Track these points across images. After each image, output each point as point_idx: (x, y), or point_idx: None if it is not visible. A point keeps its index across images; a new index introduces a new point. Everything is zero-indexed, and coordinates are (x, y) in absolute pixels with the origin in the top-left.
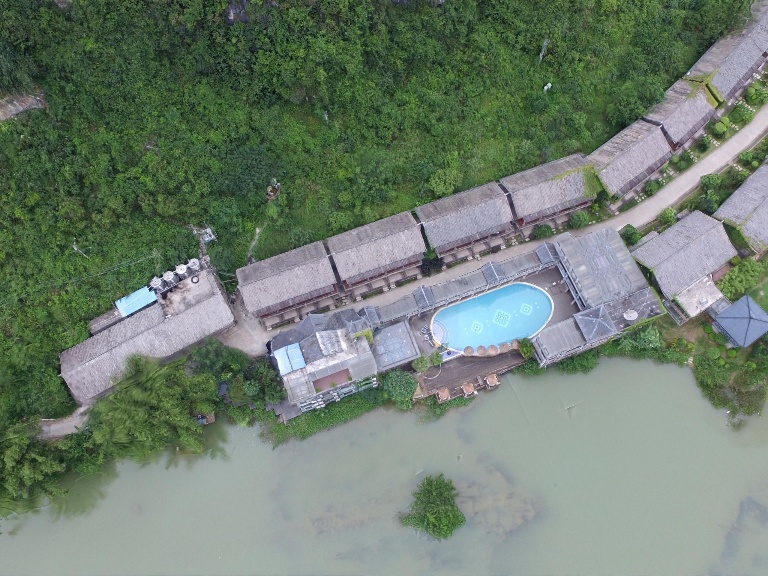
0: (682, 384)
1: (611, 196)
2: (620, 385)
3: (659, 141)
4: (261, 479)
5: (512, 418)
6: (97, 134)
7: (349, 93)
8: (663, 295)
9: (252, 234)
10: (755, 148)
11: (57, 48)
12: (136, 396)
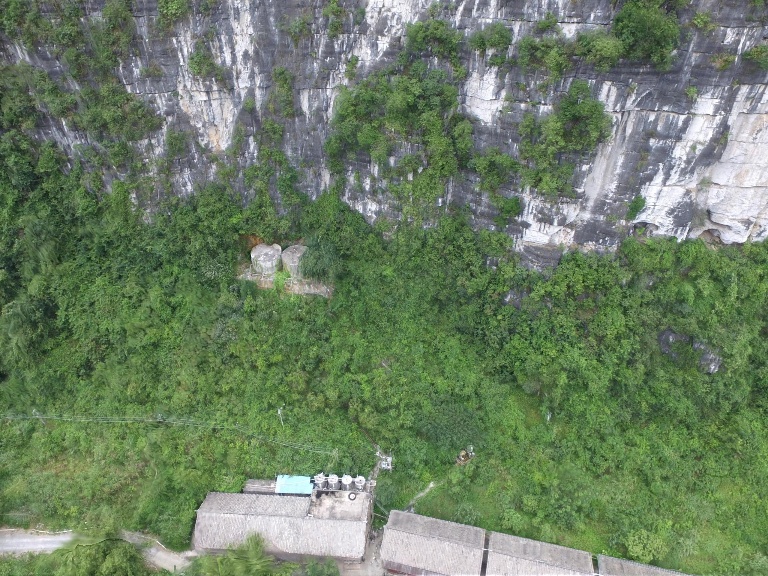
0: None
1: None
2: None
3: None
4: None
5: None
6: (352, 335)
7: (581, 407)
8: None
9: (425, 485)
10: None
11: (364, 263)
12: (238, 572)
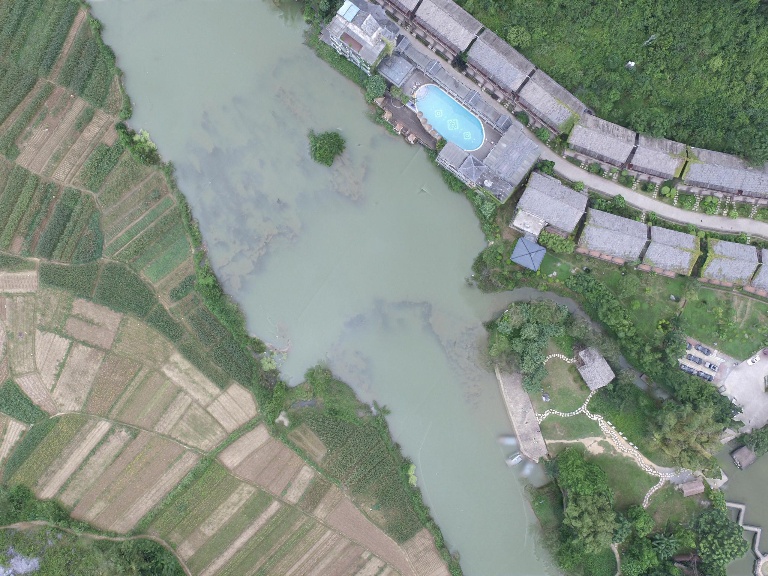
0: (475, 245)
1: (567, 142)
2: (454, 211)
3: (625, 151)
4: (284, 48)
5: (399, 162)
6: None
7: None
8: (518, 202)
9: None
10: (665, 221)
11: None
12: None
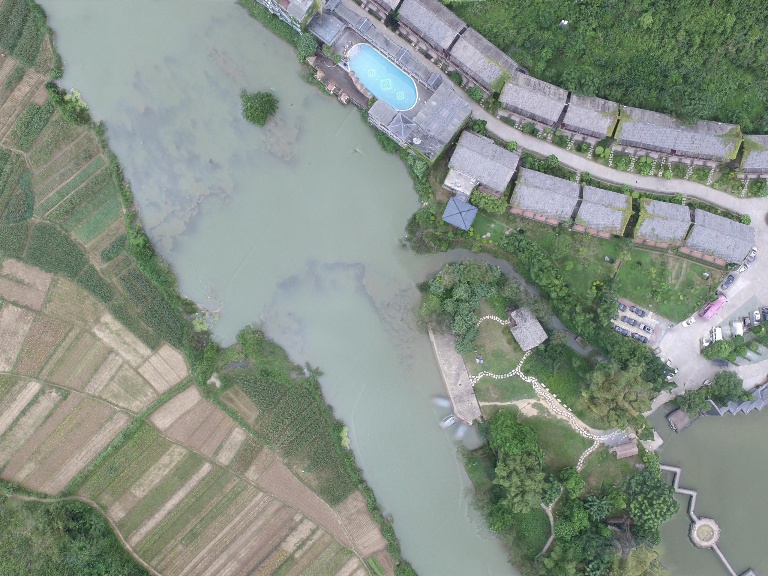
0: (409, 206)
1: (499, 100)
2: (387, 172)
3: (556, 110)
4: (217, 7)
5: (332, 123)
6: None
7: None
8: (449, 161)
9: None
10: (600, 182)
11: None
12: None
